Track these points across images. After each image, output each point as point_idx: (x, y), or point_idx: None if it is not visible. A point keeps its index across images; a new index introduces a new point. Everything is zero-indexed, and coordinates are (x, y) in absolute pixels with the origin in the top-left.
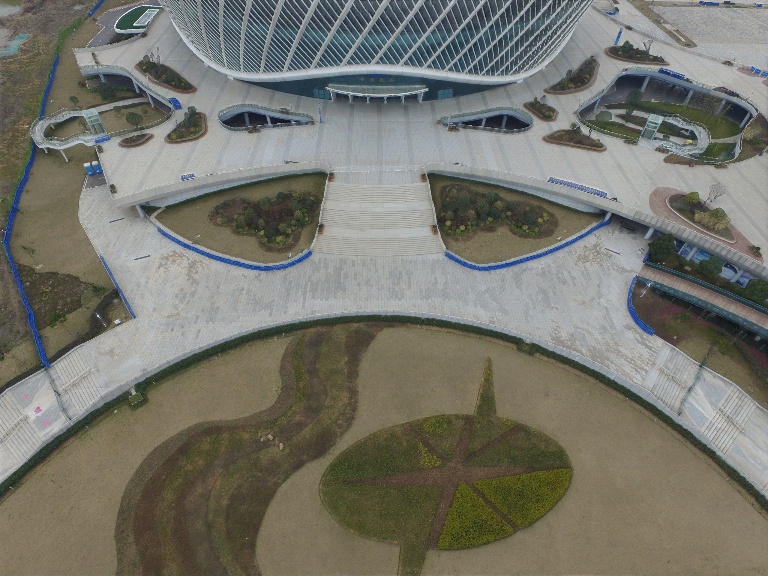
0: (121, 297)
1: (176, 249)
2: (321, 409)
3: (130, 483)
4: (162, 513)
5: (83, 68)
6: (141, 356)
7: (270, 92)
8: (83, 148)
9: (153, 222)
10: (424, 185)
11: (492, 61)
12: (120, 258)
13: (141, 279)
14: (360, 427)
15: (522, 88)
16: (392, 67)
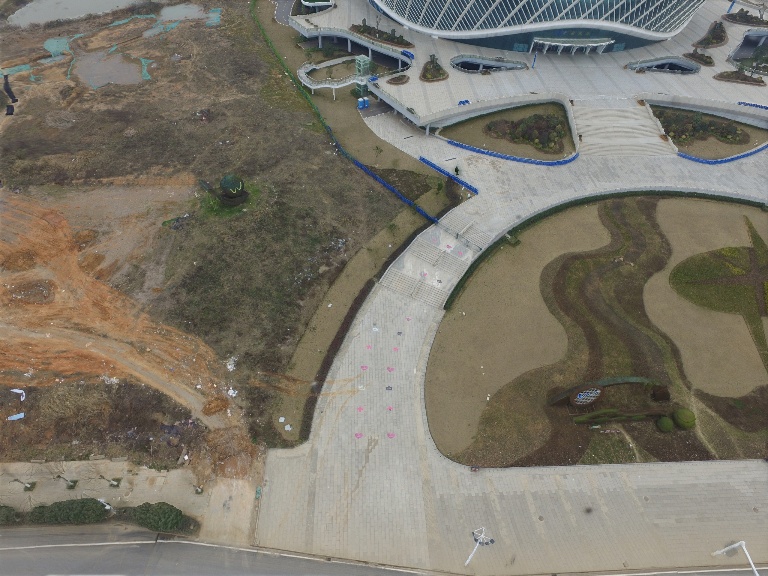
0: (457, 182)
1: (472, 154)
2: (646, 244)
3: (541, 285)
4: (574, 300)
5: (310, 30)
6: (501, 215)
7: (475, 47)
8: (339, 91)
9: (440, 137)
10: (644, 108)
11: (664, 18)
12: (434, 160)
13: (462, 172)
14: (678, 254)
15: (673, 44)
16: (595, 21)
